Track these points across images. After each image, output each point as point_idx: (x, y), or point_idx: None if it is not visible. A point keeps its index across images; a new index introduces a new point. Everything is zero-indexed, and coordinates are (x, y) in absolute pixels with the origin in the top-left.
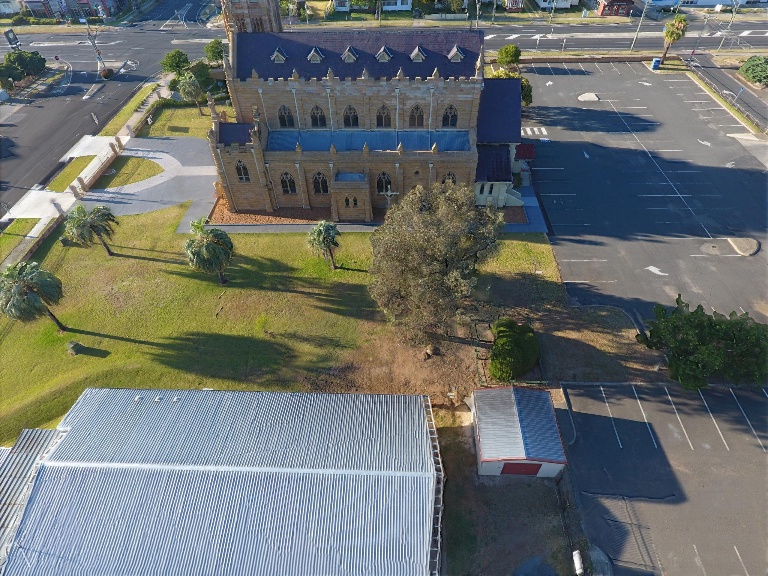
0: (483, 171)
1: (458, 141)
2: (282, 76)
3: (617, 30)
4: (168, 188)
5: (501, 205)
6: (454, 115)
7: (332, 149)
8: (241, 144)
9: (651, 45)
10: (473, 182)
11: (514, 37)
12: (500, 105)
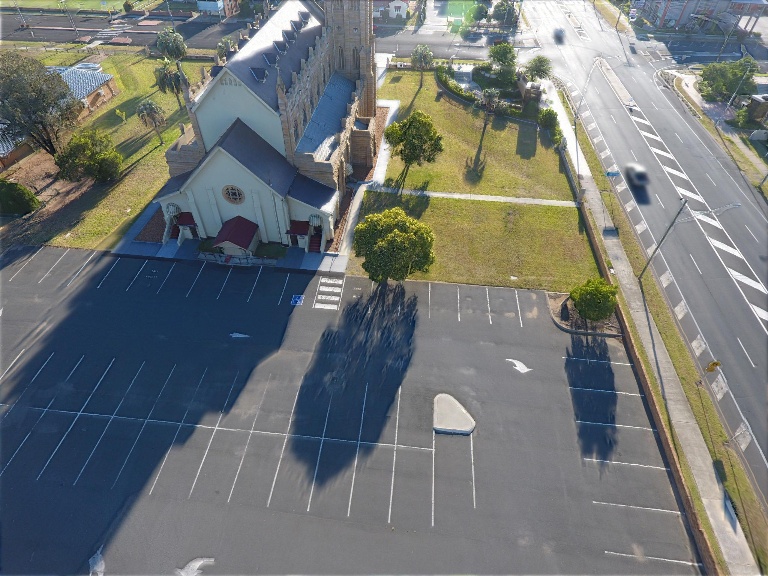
0: (174, 180)
1: None
2: None
3: None
4: None
5: None
6: None
7: None
8: None
9: None
10: None
11: None
12: None
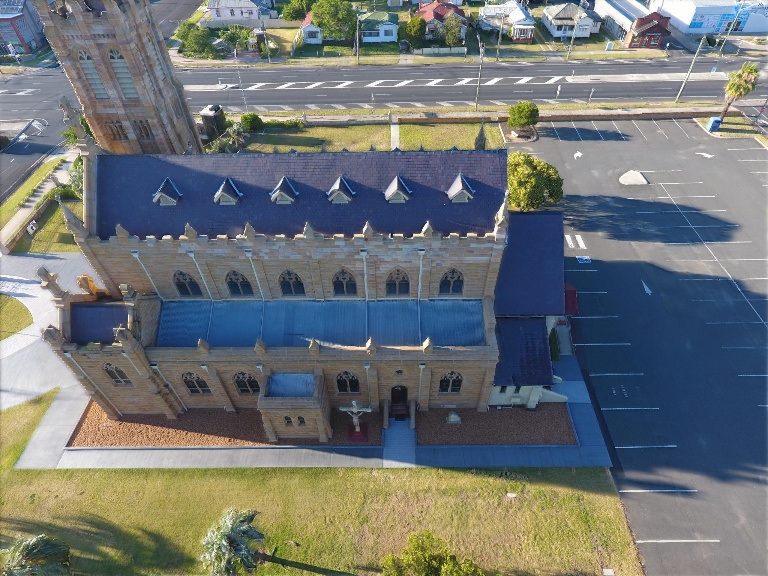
0: (506, 365)
1: (465, 318)
2: (173, 227)
3: (652, 70)
4: (29, 360)
5: (533, 406)
6: (458, 280)
7: (258, 348)
8: (107, 340)
9: (699, 92)
10: (490, 384)
11: (525, 81)
12: (530, 255)
